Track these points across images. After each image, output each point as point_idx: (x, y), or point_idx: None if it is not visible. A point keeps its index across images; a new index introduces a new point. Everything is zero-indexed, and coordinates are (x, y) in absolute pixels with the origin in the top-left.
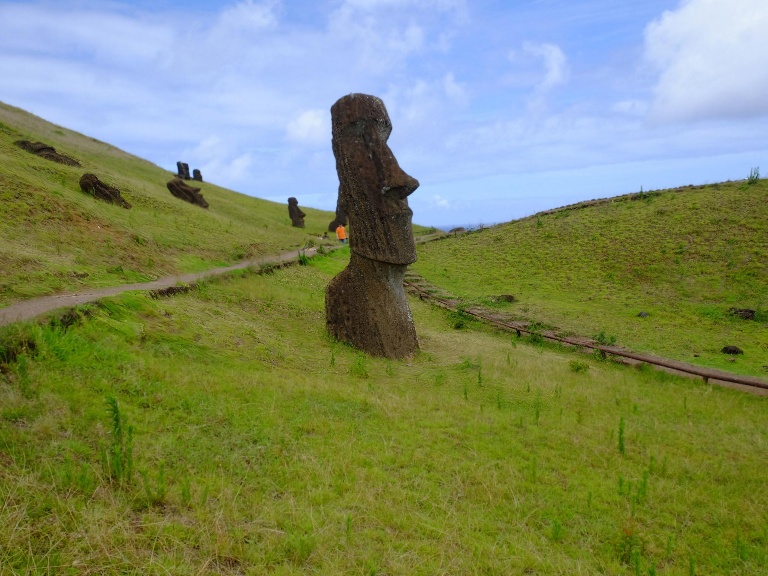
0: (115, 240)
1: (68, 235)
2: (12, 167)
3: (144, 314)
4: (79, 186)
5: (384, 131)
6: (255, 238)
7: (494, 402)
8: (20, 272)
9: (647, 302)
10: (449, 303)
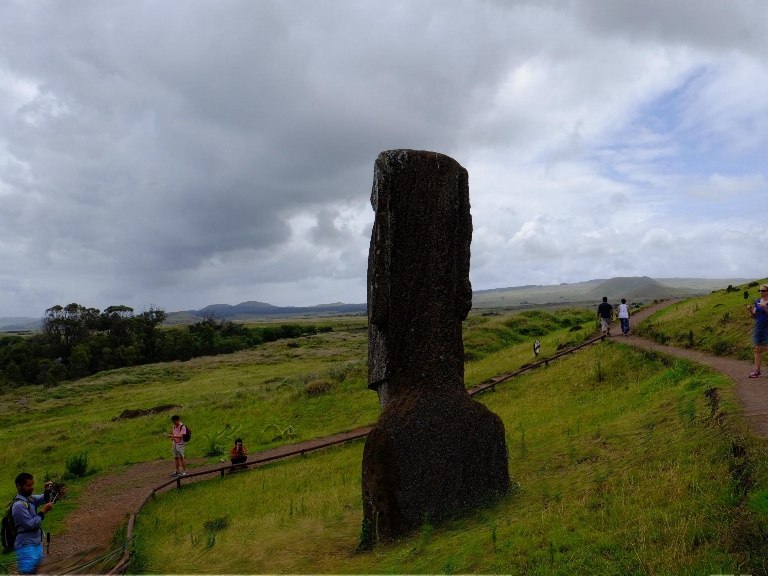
0: None
1: None
2: None
3: None
4: None
5: None
6: None
7: None
8: None
9: None
10: None
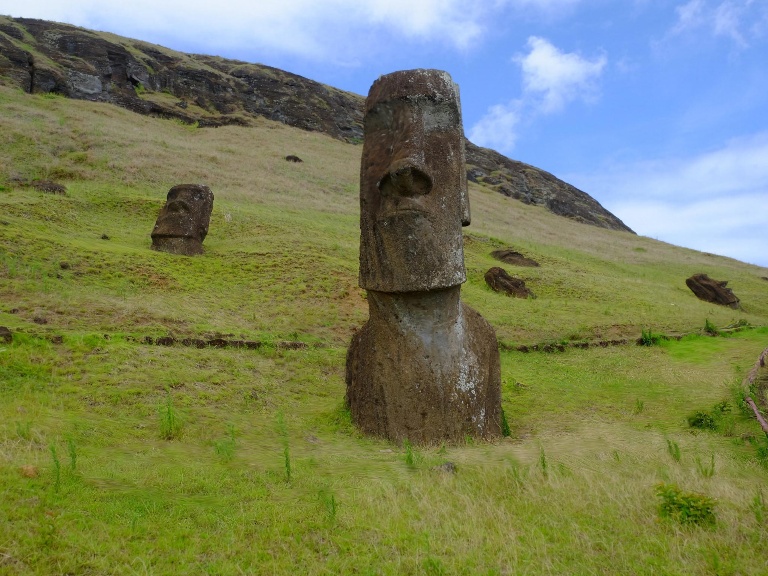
0: (365, 314)
1: (309, 309)
2: None
3: (68, 349)
4: (484, 280)
5: (439, 111)
6: (643, 319)
7: None
8: None
9: None
10: None
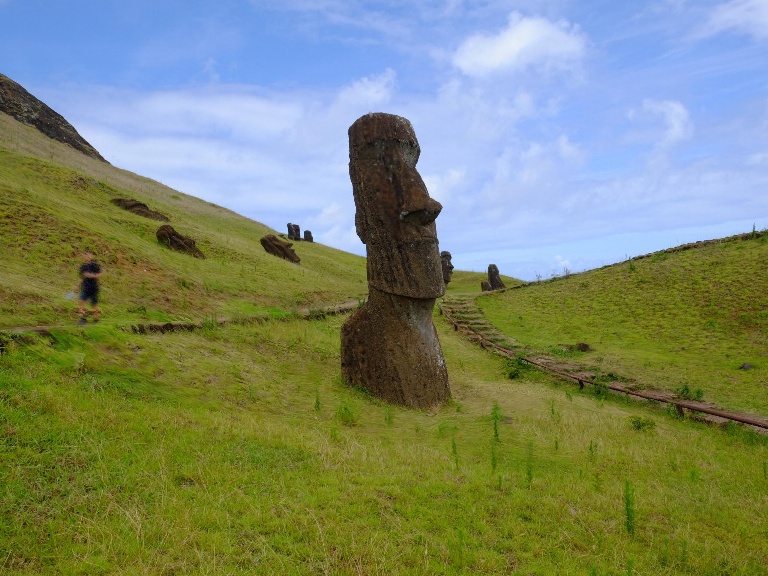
0: (156, 282)
1: (104, 276)
2: (88, 218)
3: (105, 346)
4: (156, 237)
5: (410, 153)
6: (322, 286)
7: (488, 458)
8: (8, 304)
9: (754, 353)
10: (514, 352)
